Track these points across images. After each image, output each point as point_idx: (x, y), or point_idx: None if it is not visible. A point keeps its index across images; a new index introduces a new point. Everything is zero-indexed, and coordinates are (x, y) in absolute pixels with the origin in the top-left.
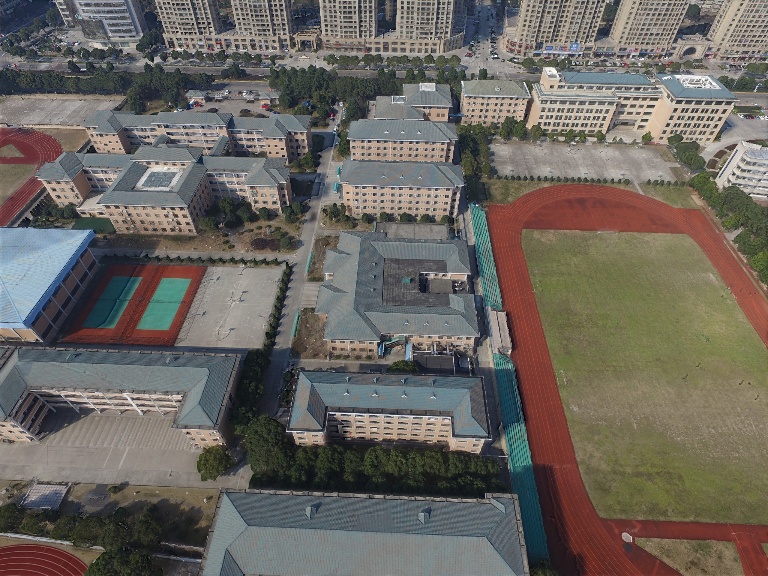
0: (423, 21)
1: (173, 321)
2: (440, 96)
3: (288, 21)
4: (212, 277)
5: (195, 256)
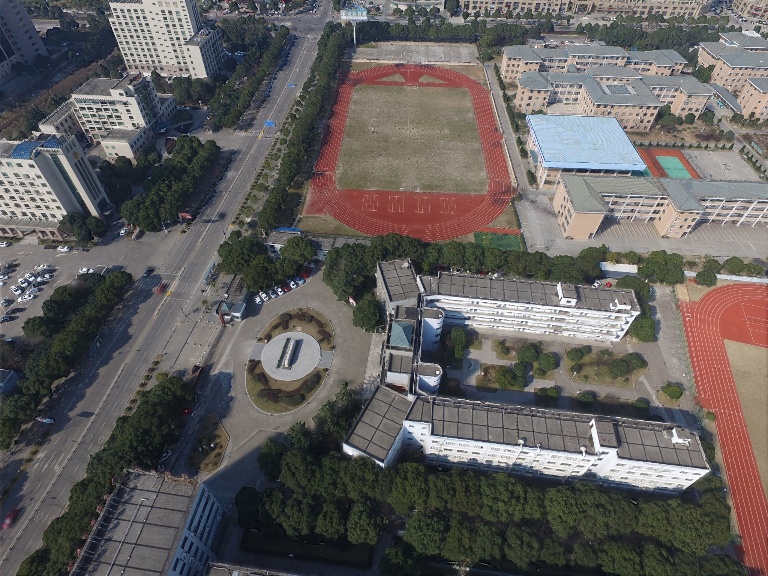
0: None
1: None
2: (765, 40)
3: None
4: (691, 156)
5: (662, 144)
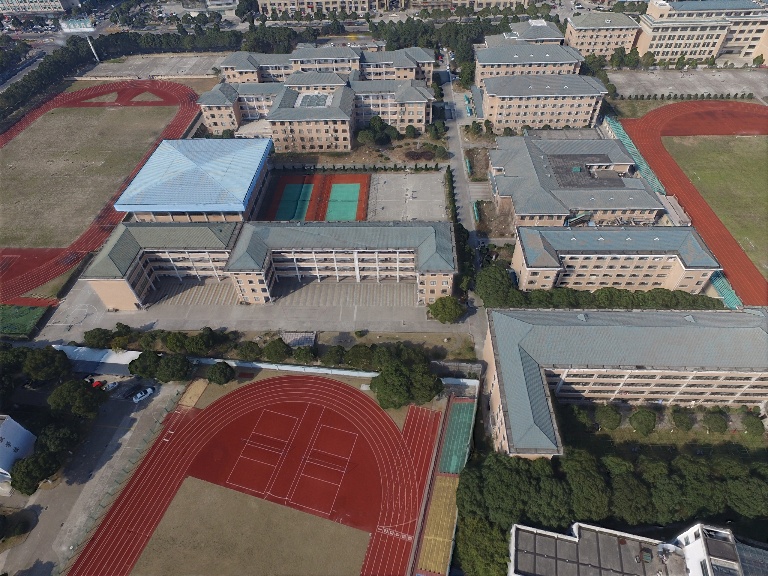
0: None
1: (357, 214)
2: (552, 30)
3: None
4: (379, 181)
5: (356, 167)
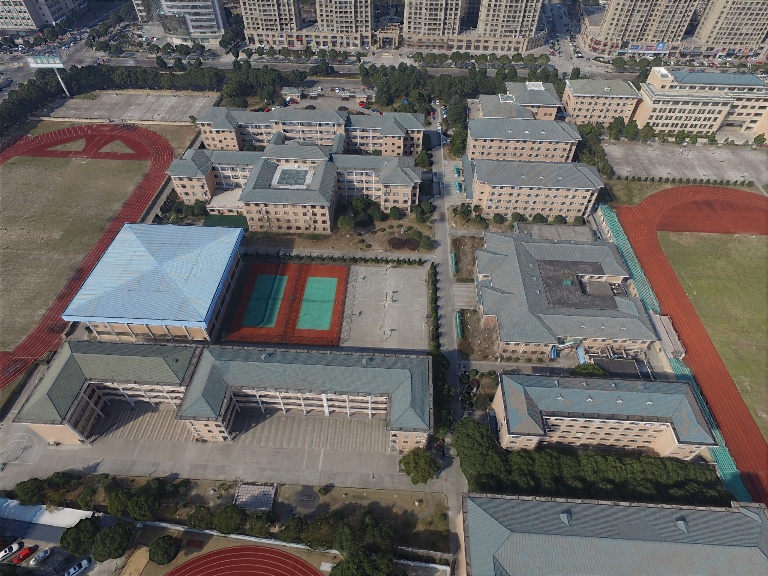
0: (509, 19)
1: (331, 321)
2: (549, 95)
3: (371, 18)
4: (358, 276)
5: (335, 255)
